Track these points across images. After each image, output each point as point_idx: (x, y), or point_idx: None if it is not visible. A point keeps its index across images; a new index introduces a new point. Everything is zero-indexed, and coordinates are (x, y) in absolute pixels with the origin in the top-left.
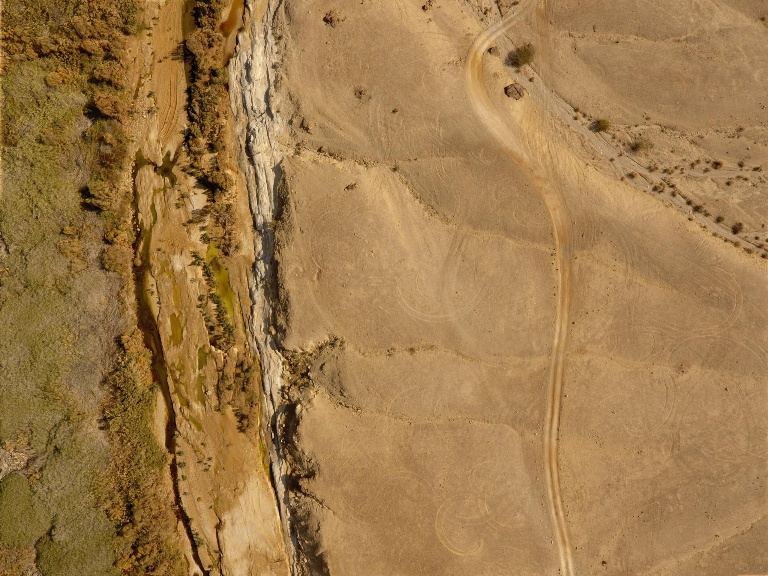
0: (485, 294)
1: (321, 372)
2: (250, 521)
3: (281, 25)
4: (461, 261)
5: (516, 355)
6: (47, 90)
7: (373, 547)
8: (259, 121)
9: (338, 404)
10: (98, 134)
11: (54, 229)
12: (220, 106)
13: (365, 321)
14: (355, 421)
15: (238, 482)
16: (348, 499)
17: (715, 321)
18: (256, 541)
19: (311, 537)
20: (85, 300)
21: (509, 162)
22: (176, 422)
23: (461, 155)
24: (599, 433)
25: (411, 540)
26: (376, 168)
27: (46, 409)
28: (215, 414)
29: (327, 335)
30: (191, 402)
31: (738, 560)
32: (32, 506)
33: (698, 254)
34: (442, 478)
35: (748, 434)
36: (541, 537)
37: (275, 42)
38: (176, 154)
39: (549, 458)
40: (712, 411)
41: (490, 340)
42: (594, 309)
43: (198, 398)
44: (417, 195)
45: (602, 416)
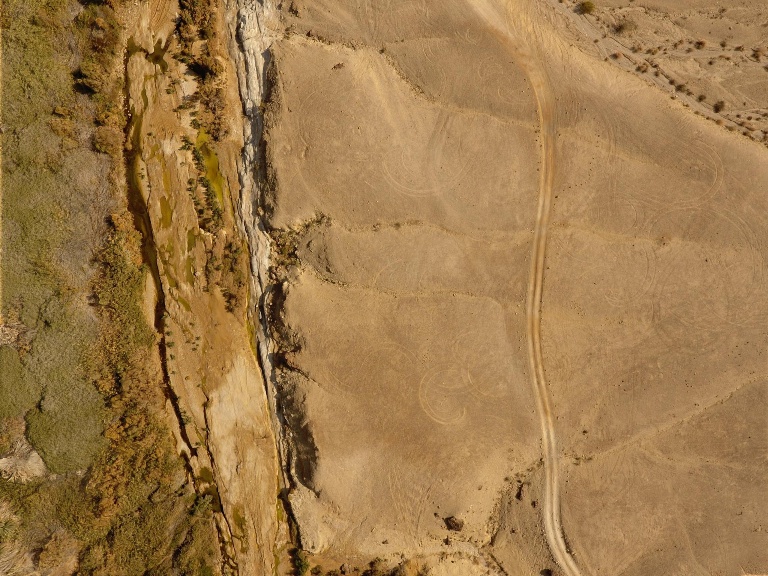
0: (470, 169)
1: (308, 249)
2: (237, 398)
3: None
4: (446, 138)
5: (500, 229)
6: None
7: (357, 417)
8: (249, 8)
9: (324, 280)
10: (90, 19)
11: (46, 109)
12: None
13: (351, 197)
14: (341, 295)
15: (226, 361)
16: (333, 371)
17: (696, 193)
18: (243, 418)
19: (297, 409)
20: (76, 177)
21: (494, 41)
22: (165, 302)
23: (447, 35)
24: (581, 304)
25: (395, 409)
26: (364, 50)
27: (37, 284)
28: (203, 295)
29: (314, 212)
30: (180, 283)
31: (717, 428)
32: (22, 378)
33: (680, 128)
34: (426, 349)
35: (728, 303)
36: (523, 406)
37: None
38: (167, 42)
39: (531, 329)
40: (692, 281)
41: (474, 214)
42: (577, 183)
43: (187, 279)
44: (404, 76)
45: (584, 287)
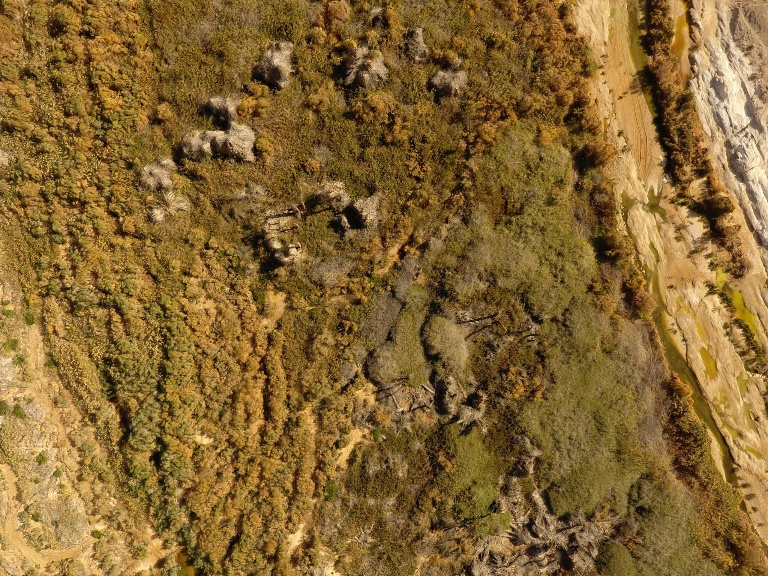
0: None
1: None
2: None
3: (748, 35)
4: None
5: None
6: (539, 151)
7: None
8: (742, 136)
9: None
10: (591, 184)
11: (583, 289)
12: (695, 130)
13: None
14: None
15: None
16: None
17: None
18: None
19: None
20: (636, 353)
21: None
22: (733, 455)
23: None
24: None
25: None
26: None
27: (626, 471)
28: None
29: None
30: (744, 432)
31: None
32: (640, 572)
33: None
34: None
35: None
36: None
37: (744, 54)
38: (659, 188)
39: None
40: None
41: None
42: None
43: (749, 427)
44: None
45: None
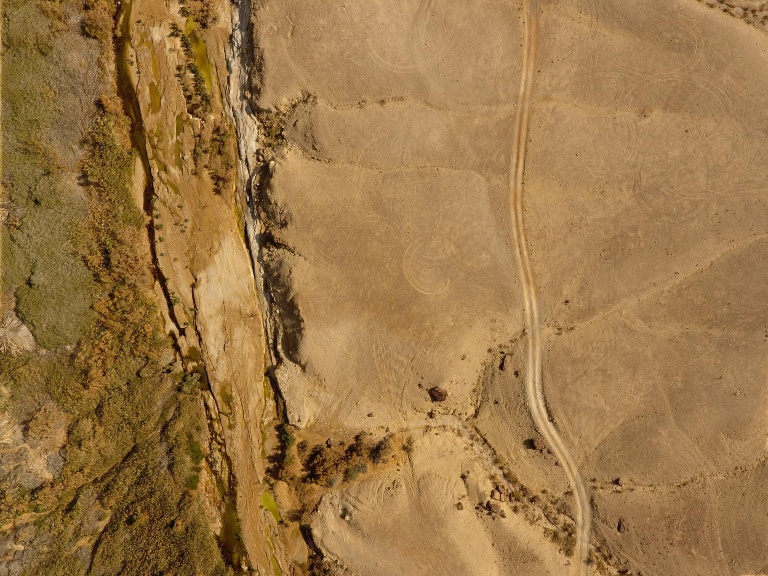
0: (453, 45)
1: (294, 129)
2: (225, 278)
3: None
4: (431, 16)
5: (483, 104)
6: None
7: (342, 288)
8: None
9: (310, 158)
10: None
11: None
12: None
13: (337, 74)
14: (326, 172)
15: (213, 242)
16: (319, 244)
17: (676, 65)
18: (230, 298)
19: (283, 284)
20: (65, 59)
21: None
22: (154, 186)
23: None
24: (563, 175)
25: (379, 280)
26: None
27: (27, 162)
28: (192, 178)
29: (300, 91)
30: (168, 166)
31: (697, 295)
32: (12, 253)
33: (661, 2)
34: (410, 221)
35: (707, 172)
36: (506, 276)
37: None
38: None
39: (514, 201)
40: (673, 151)
41: (458, 89)
42: (559, 58)
43: (175, 163)
44: None
45: (566, 159)
